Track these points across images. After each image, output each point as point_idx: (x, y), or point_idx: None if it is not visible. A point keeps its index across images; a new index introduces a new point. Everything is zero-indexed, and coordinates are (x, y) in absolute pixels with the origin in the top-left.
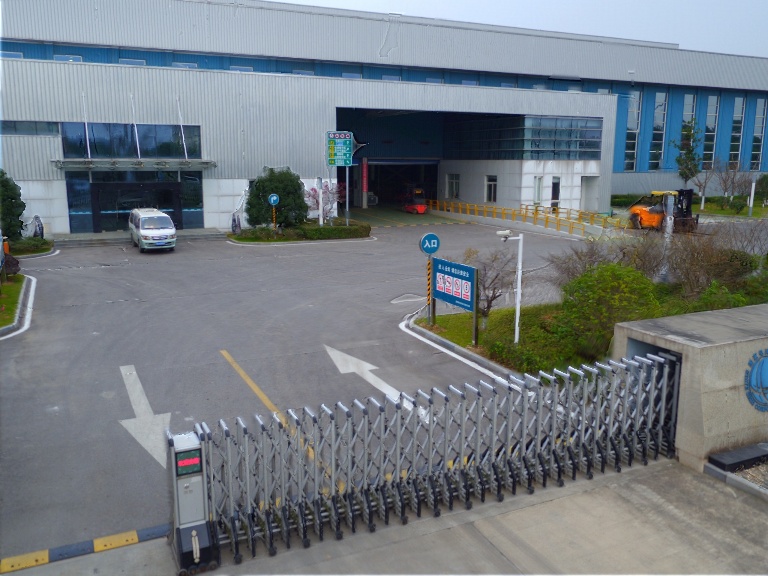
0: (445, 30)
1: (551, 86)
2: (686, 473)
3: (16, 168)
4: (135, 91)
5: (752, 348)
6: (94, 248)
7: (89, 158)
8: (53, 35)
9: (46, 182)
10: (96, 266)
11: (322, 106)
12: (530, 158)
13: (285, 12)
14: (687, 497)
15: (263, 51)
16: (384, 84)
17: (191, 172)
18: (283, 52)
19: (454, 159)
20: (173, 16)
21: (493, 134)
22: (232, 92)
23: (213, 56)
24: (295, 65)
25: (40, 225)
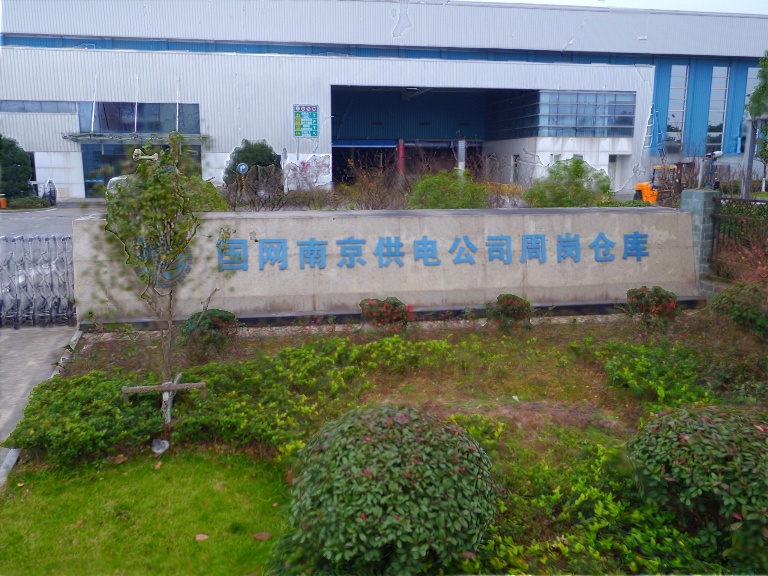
0: (486, 9)
1: (569, 59)
2: (65, 333)
3: (41, 141)
4: (141, 73)
5: None
6: (87, 208)
7: (92, 131)
8: (109, 31)
9: (65, 153)
10: (50, 217)
11: (316, 84)
12: (547, 135)
13: None
14: (19, 344)
15: (296, 38)
16: (381, 62)
17: (191, 146)
18: (315, 38)
19: (491, 140)
20: (212, 9)
21: (519, 112)
22: (229, 72)
23: (252, 45)
24: None
25: (52, 189)
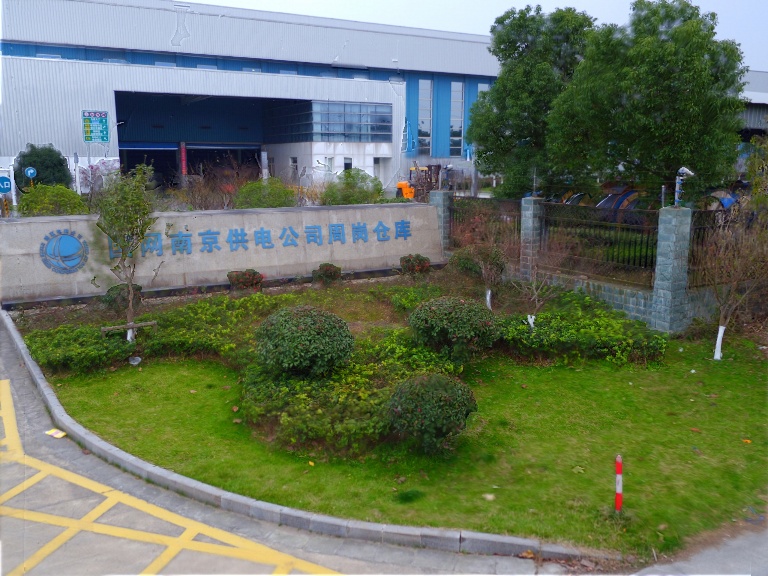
0: (257, 23)
1: (335, 74)
2: None
3: None
4: None
5: (49, 228)
6: None
7: None
8: None
9: None
10: None
11: (99, 89)
12: (320, 140)
13: (89, 3)
14: None
15: (67, 40)
16: (163, 70)
17: None
18: (88, 41)
19: None
20: None
21: (294, 119)
22: (3, 75)
23: (18, 44)
24: (105, 54)
25: None
